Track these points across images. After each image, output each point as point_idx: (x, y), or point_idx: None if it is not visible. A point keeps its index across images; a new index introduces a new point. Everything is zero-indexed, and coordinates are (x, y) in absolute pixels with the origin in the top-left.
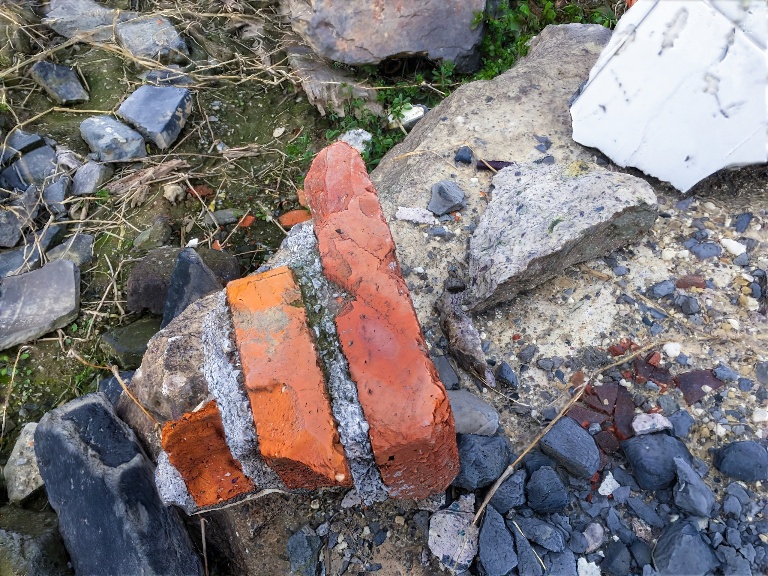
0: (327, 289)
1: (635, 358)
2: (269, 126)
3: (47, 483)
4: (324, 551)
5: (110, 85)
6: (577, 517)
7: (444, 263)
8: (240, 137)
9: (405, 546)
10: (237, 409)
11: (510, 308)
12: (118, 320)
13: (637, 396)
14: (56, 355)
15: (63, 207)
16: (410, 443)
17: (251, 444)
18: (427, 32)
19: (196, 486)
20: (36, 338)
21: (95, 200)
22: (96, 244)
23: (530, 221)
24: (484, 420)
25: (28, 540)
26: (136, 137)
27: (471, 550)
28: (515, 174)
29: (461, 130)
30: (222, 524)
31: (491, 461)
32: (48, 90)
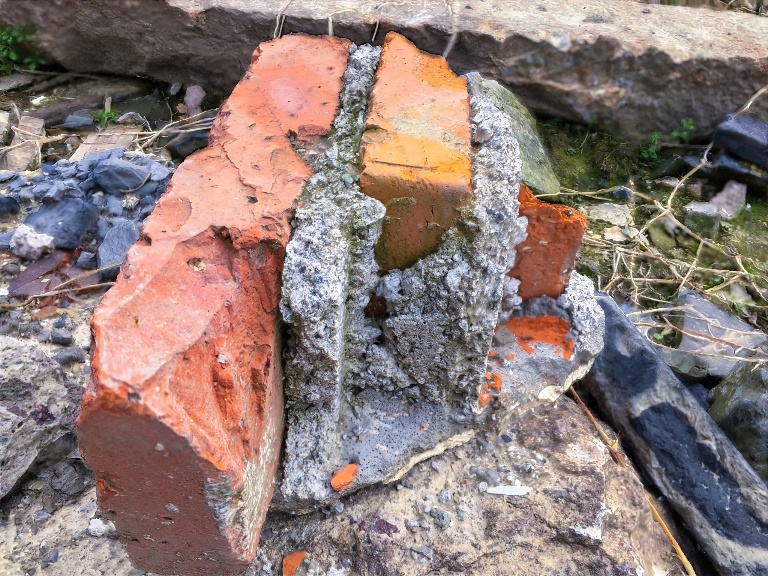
0: None
1: None
2: None
3: None
4: None
5: None
6: None
7: (43, 534)
8: None
9: None
10: None
11: None
12: None
13: (10, 269)
14: None
15: None
16: None
17: None
18: None
19: None
20: None
21: None
22: None
23: None
24: None
25: None
26: None
27: None
28: None
29: None
30: None
31: None
32: None
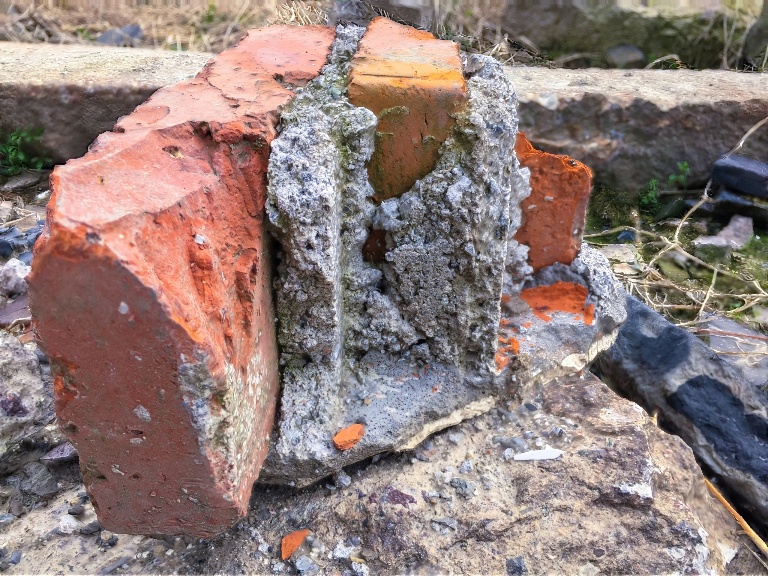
0: None
1: None
2: None
3: None
4: None
5: None
6: None
7: (6, 536)
8: None
9: None
10: None
11: None
12: None
13: None
14: None
15: None
16: None
17: None
18: None
19: None
20: None
21: None
22: None
23: None
24: None
25: None
26: None
27: None
28: None
29: None
30: None
31: None
32: None
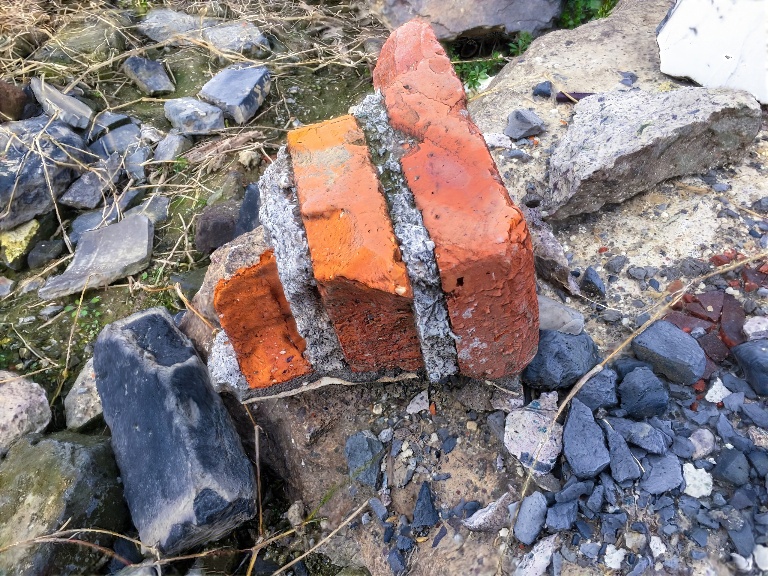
0: (393, 137)
1: (743, 267)
2: (344, 105)
3: (103, 396)
4: (386, 460)
5: (195, 78)
6: (680, 425)
7: (522, 182)
8: (316, 116)
9: (478, 454)
10: (291, 238)
11: (595, 224)
12: (187, 267)
13: (747, 301)
14: (125, 300)
15: (143, 174)
16: (481, 260)
17: (305, 275)
18: (504, 6)
19: (249, 365)
20: (107, 283)
21: (173, 168)
22: (171, 205)
23: (616, 129)
24: (568, 317)
25: (79, 449)
26: (215, 110)
27: (554, 447)
28: (598, 100)
29: (539, 68)
30: (278, 438)
31: (576, 355)
32: (138, 83)
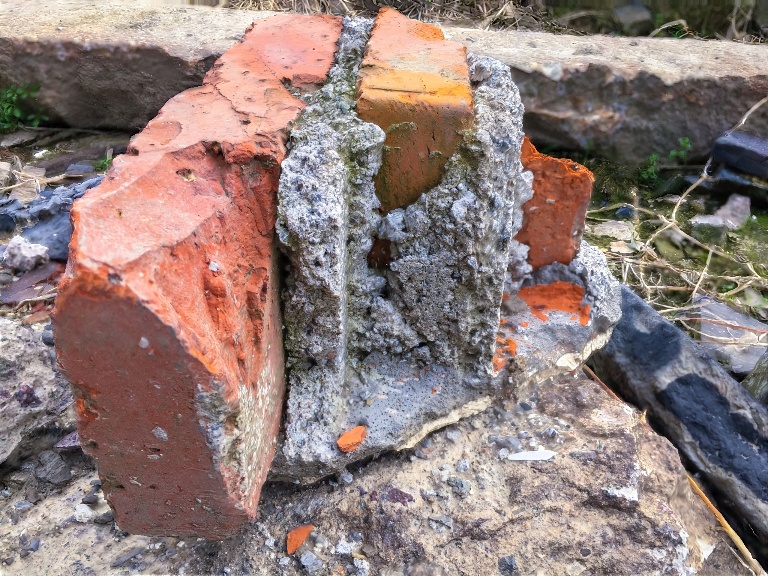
0: None
1: None
2: None
3: None
4: None
5: None
6: None
7: (24, 523)
8: None
9: None
10: None
11: None
12: None
13: (2, 278)
14: None
15: None
16: None
17: None
18: None
19: None
20: None
21: None
22: None
23: None
24: None
25: None
26: None
27: None
28: None
29: None
30: None
31: None
32: None
